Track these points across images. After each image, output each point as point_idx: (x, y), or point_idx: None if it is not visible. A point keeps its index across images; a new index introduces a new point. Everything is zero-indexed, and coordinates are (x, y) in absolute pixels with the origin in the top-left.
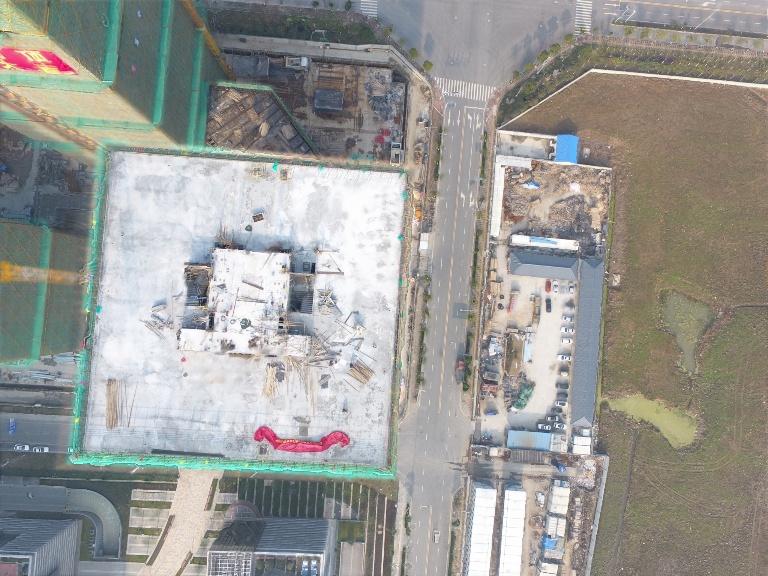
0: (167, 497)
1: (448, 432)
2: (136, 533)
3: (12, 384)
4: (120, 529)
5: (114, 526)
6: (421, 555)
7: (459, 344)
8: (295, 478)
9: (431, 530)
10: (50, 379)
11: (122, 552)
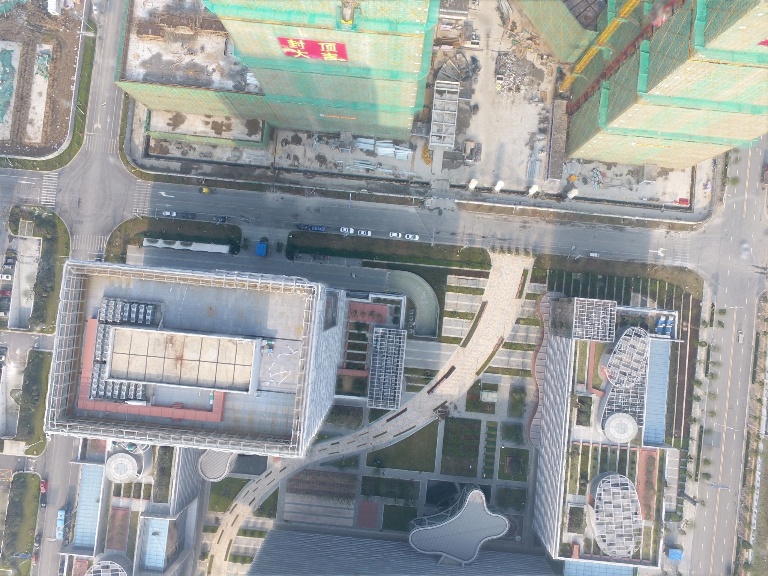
0: (480, 284)
1: (753, 236)
2: (451, 316)
3: (335, 173)
4: (438, 310)
5: (427, 311)
6: (725, 354)
7: (764, 151)
8: (602, 272)
9: (735, 330)
10: (372, 169)
11: (438, 333)
